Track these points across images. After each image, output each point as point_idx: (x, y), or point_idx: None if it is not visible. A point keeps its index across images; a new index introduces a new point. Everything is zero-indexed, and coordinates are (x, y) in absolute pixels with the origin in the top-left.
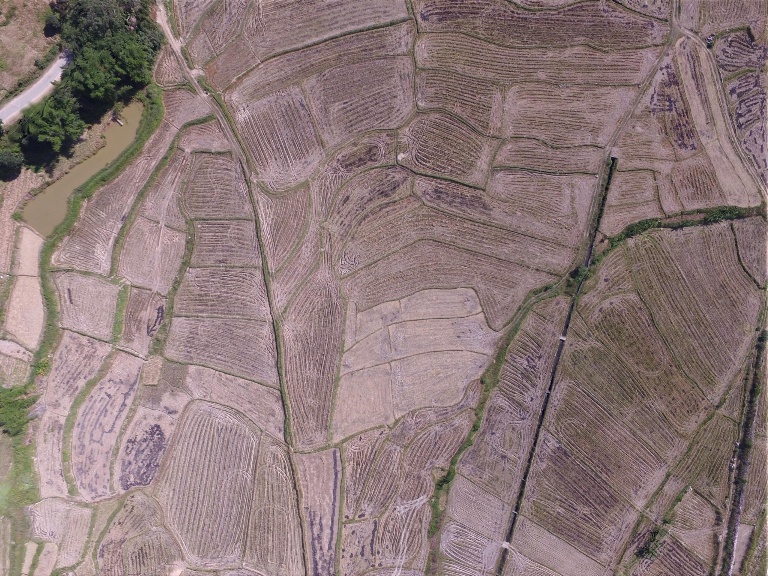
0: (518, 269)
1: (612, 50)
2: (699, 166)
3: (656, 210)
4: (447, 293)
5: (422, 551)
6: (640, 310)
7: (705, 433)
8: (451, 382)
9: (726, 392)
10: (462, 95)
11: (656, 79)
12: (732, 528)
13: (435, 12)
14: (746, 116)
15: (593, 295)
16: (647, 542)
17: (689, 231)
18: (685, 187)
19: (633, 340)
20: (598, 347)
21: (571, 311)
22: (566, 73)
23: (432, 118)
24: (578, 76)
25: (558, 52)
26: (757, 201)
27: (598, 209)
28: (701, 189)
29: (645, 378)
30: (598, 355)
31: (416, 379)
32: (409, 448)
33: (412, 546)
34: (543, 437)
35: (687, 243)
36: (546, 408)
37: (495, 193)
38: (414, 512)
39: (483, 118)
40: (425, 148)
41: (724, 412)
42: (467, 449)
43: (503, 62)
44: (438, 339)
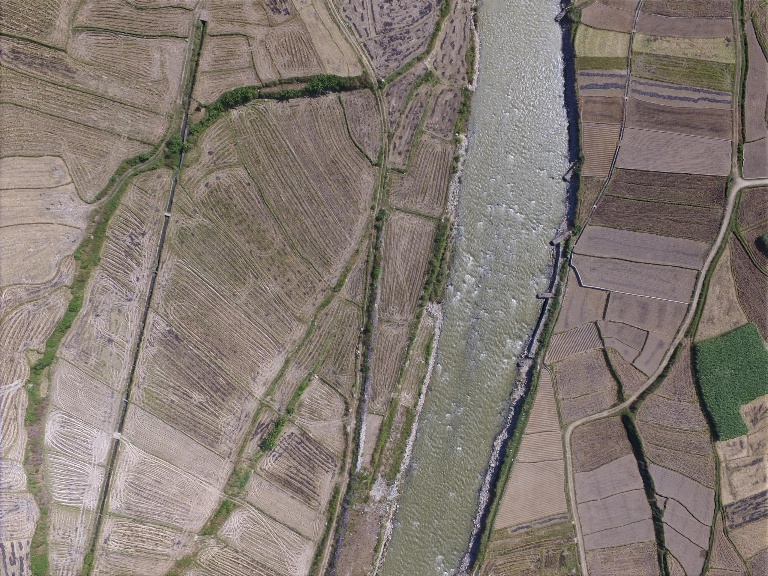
0: (109, 137)
1: None
2: (294, 32)
3: (252, 78)
4: (33, 161)
5: (19, 440)
6: (248, 186)
7: (327, 318)
8: (42, 257)
9: (343, 273)
10: None
11: None
12: (358, 417)
13: None
14: None
15: (197, 169)
16: (270, 433)
17: (296, 103)
18: (281, 54)
19: (242, 217)
20: (206, 224)
21: (175, 185)
22: None
23: None
24: None
25: None
26: (358, 71)
27: (190, 75)
28: (297, 56)
29: (257, 258)
30: (206, 233)
31: (3, 254)
32: None
33: (7, 435)
34: (152, 320)
35: (294, 116)
36: (153, 288)
37: (78, 55)
38: (8, 398)
39: None
40: None
41: (346, 296)
42: (70, 332)
43: None
44: (26, 211)
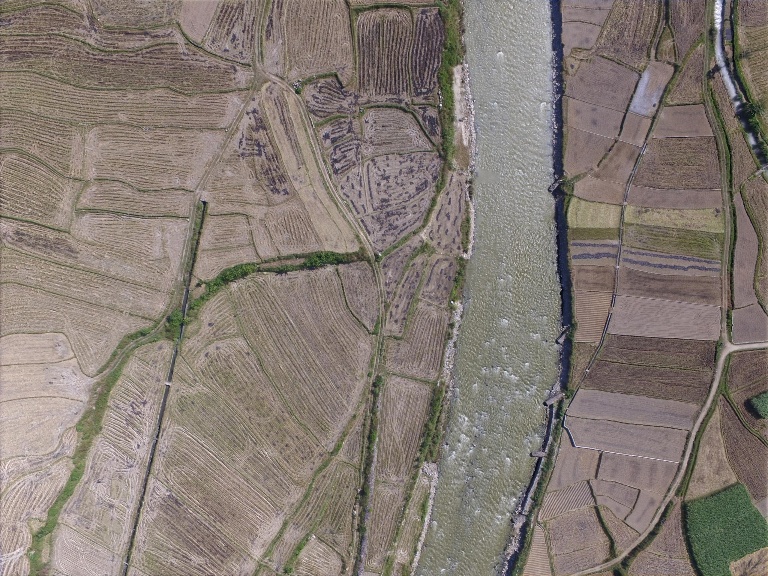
0: (111, 313)
1: (195, 93)
2: (293, 211)
3: (252, 255)
4: (36, 338)
5: None
6: (248, 355)
7: (324, 480)
8: (45, 430)
9: (340, 438)
10: (39, 136)
11: (243, 123)
12: None
13: (5, 51)
14: (341, 162)
15: (197, 340)
16: None
17: (294, 275)
18: (280, 232)
19: (242, 386)
20: (206, 393)
21: (176, 356)
22: (148, 115)
23: (9, 158)
24: (161, 119)
25: (139, 94)
26: (355, 247)
27: (191, 253)
28: (296, 234)
29: (256, 424)
30: (206, 401)
31: (7, 427)
32: (2, 498)
33: None
34: (152, 485)
35: (292, 288)
36: (154, 455)
37: (81, 236)
38: (10, 565)
39: (63, 159)
40: (2, 189)
41: (343, 458)
42: (72, 498)
43: (80, 103)
44: (29, 385)
